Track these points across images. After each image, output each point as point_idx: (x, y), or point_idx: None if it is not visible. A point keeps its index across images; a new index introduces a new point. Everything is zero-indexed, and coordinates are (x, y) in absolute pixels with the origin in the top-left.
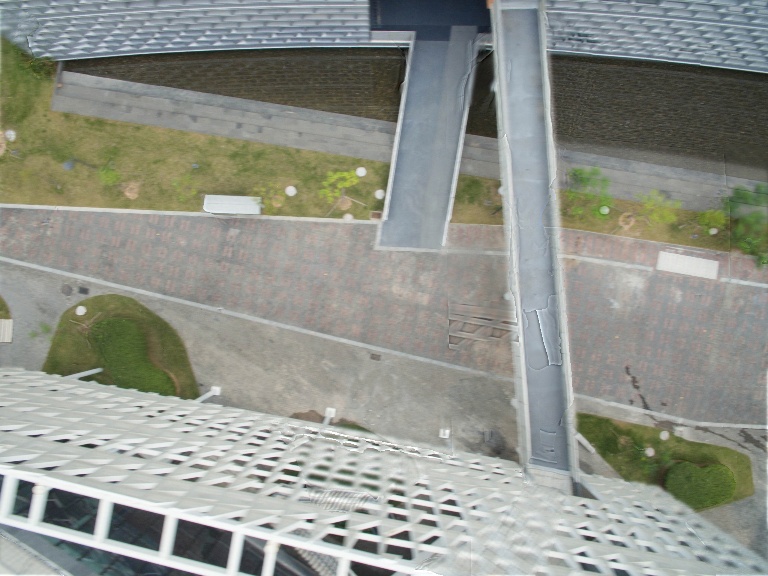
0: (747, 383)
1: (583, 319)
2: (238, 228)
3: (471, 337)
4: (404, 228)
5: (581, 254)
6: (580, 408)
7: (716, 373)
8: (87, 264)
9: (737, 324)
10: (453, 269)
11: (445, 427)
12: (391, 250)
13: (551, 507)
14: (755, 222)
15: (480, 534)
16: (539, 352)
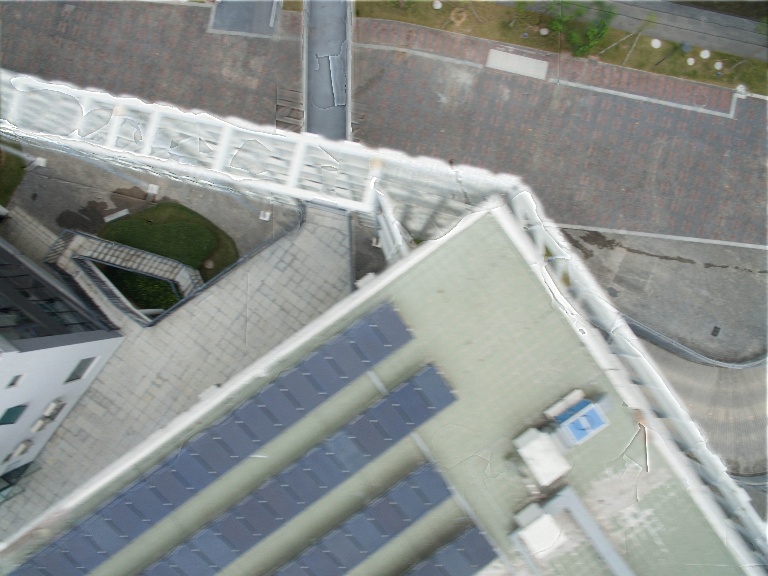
0: (569, 183)
1: (410, 111)
2: (73, 4)
3: (298, 123)
4: (237, 12)
5: (412, 48)
6: (402, 199)
7: (539, 172)
8: None
9: (563, 125)
10: (284, 55)
11: (266, 210)
12: (223, 33)
13: (330, 247)
14: (586, 24)
15: (257, 268)
16: (325, 92)
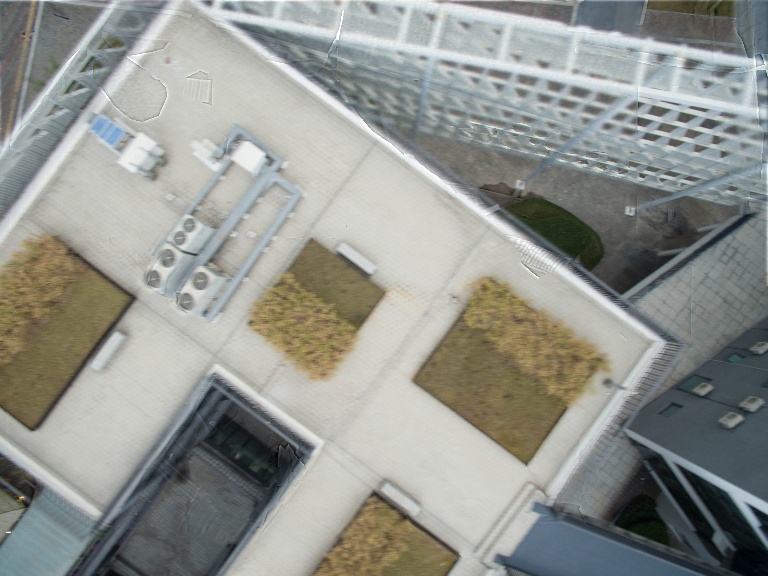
0: None
1: None
2: (437, 2)
3: (659, 120)
4: (599, 10)
5: None
6: None
7: None
8: (287, 29)
9: None
10: None
11: (631, 205)
12: (585, 32)
13: None
14: None
15: (702, 261)
16: (767, 89)
